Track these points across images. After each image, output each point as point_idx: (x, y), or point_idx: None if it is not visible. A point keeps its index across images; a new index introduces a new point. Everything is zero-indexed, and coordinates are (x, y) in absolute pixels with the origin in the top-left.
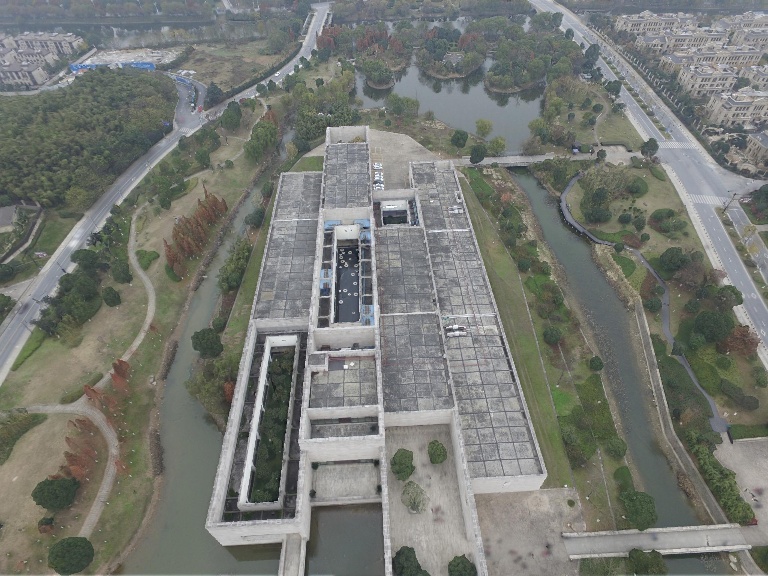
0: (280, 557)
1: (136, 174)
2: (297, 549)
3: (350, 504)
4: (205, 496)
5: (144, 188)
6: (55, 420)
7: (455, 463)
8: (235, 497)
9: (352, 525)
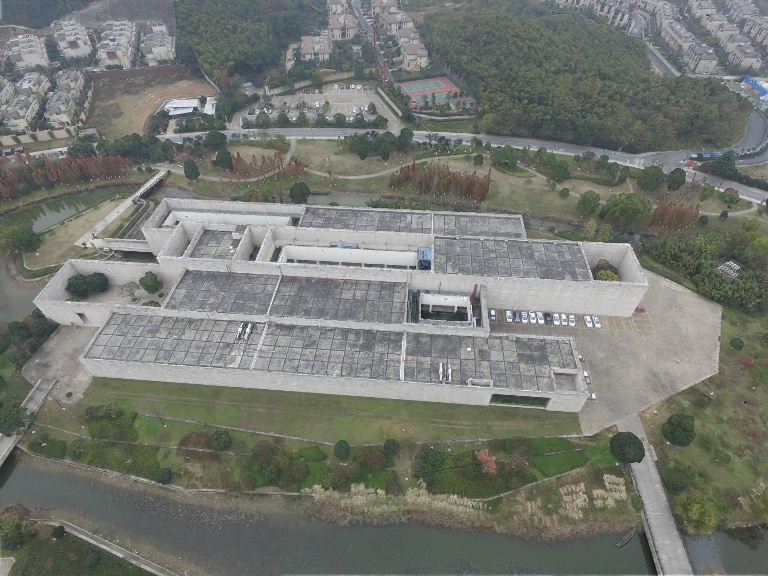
0: None
1: None
2: None
3: None
4: None
5: None
6: None
7: None
8: None
9: None
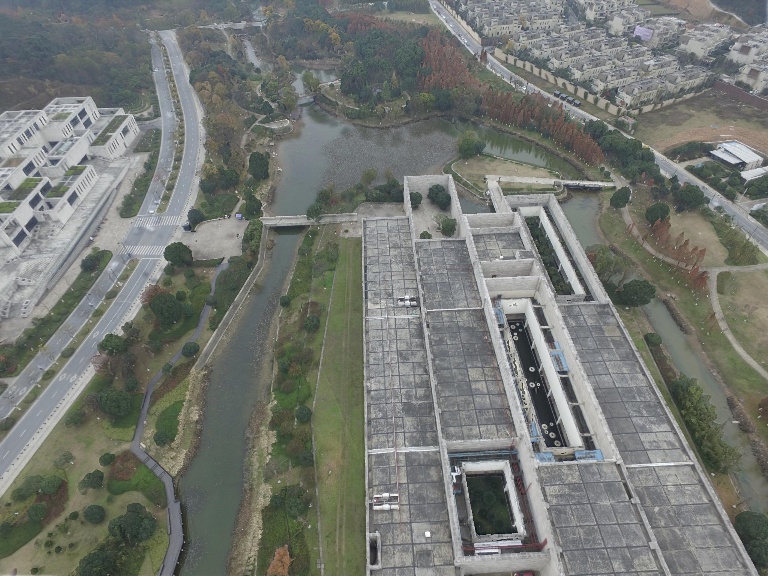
0: None
1: None
2: None
3: None
4: None
5: None
6: (717, 262)
7: None
8: None
9: None
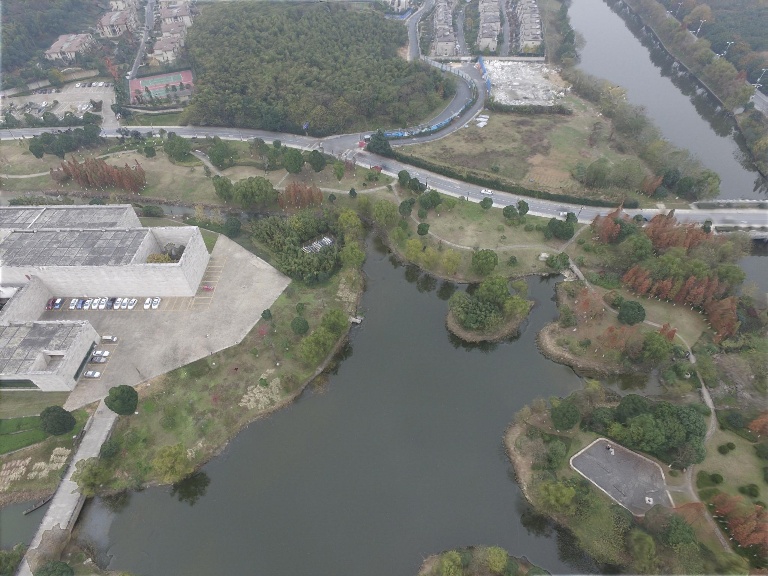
0: None
1: (238, 135)
2: None
3: None
4: None
5: (206, 143)
6: None
7: None
8: None
9: None
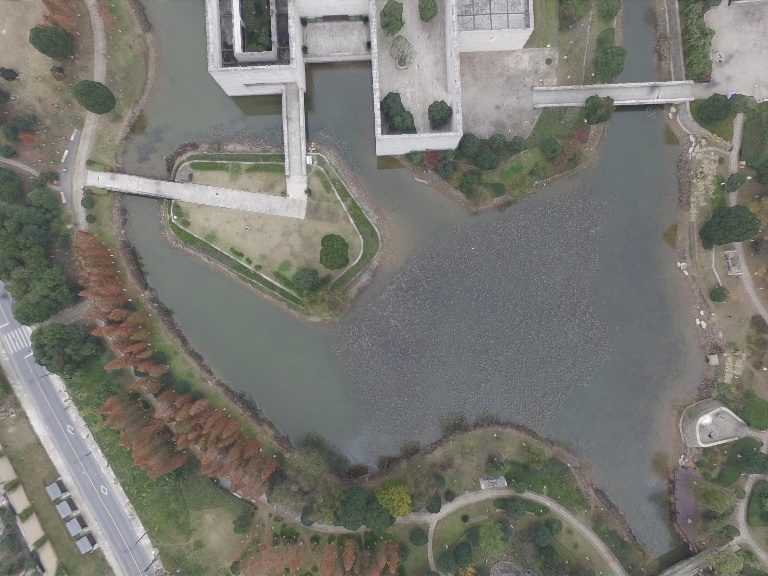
0: (282, 103)
1: None
2: (296, 98)
3: (341, 61)
4: (201, 56)
5: None
6: None
7: (445, 21)
8: (230, 49)
9: (344, 80)
